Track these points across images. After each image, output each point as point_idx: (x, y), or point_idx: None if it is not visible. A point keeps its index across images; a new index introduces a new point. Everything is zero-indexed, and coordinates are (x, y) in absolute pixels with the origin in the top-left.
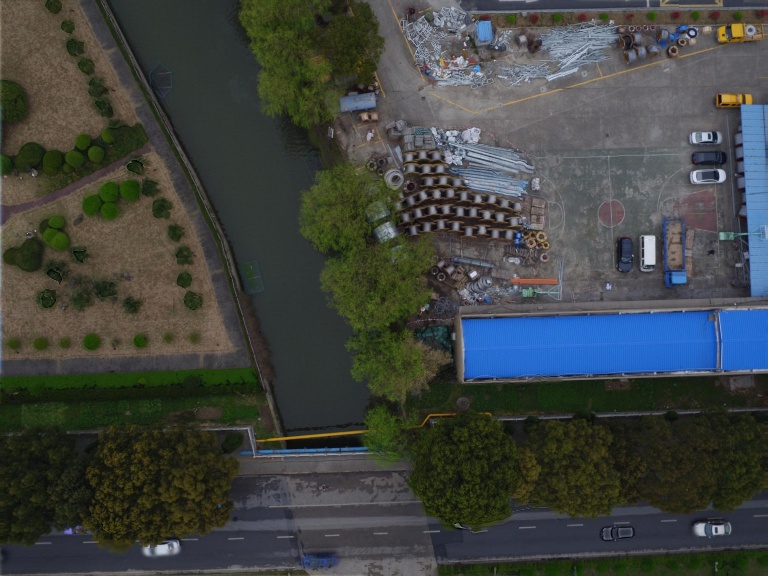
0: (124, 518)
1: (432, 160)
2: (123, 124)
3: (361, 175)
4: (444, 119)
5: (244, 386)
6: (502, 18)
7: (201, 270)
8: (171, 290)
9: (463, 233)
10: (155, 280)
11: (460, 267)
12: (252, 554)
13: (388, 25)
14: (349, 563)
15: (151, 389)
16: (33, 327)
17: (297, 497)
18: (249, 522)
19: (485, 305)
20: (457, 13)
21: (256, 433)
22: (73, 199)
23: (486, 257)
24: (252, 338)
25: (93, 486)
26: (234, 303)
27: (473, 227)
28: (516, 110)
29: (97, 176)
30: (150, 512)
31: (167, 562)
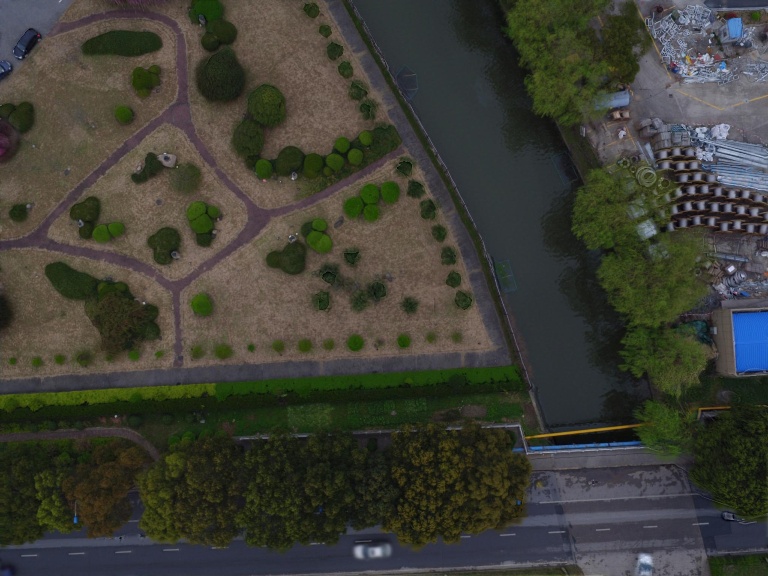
0: (436, 516)
1: (687, 157)
2: (377, 126)
3: (614, 173)
4: (692, 116)
5: (510, 384)
6: (746, 15)
7: (459, 270)
8: (431, 290)
9: (718, 228)
10: (416, 280)
11: (716, 262)
12: (524, 550)
13: (634, 24)
14: (620, 557)
15: (418, 388)
16: (296, 329)
17: (567, 492)
18: (520, 518)
19: (746, 299)
20: (701, 11)
21: (524, 430)
22: (332, 202)
23: (739, 252)
24: (516, 336)
25: (400, 485)
26: (493, 302)
27: (729, 222)
28: (762, 106)
29: (354, 178)
30: (460, 509)
31: (440, 559)
